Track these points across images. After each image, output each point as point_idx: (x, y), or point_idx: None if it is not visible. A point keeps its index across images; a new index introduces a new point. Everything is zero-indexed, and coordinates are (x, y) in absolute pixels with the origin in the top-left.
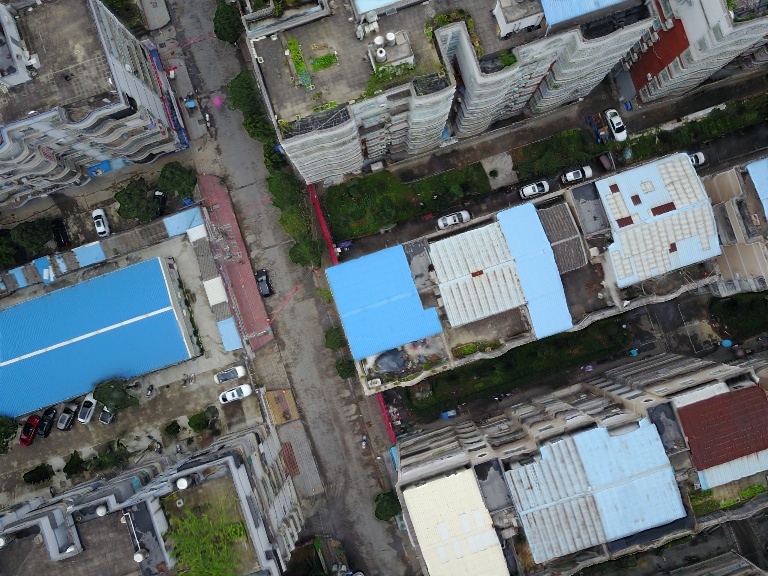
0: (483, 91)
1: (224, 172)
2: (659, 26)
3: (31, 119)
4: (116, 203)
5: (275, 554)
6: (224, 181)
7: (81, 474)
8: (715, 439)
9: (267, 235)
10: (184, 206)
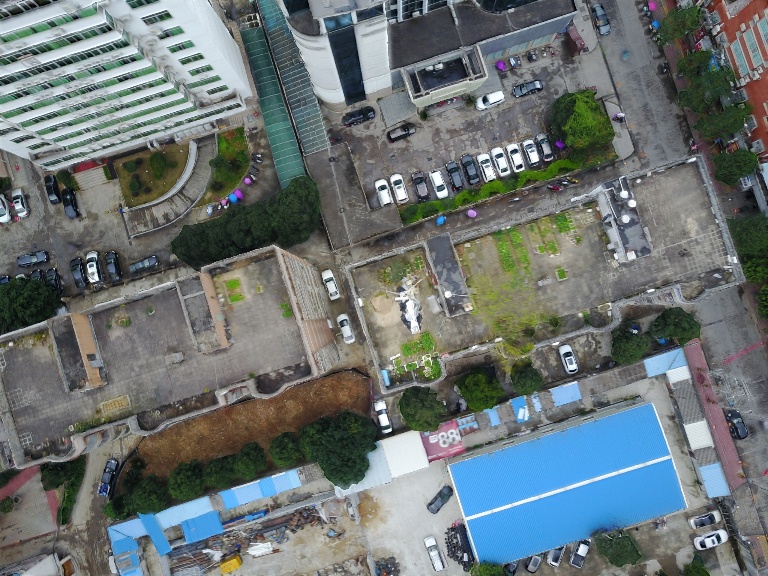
0: None
1: (691, 308)
2: None
3: None
4: (580, 338)
5: None
6: None
7: None
8: None
9: (737, 374)
10: (671, 348)
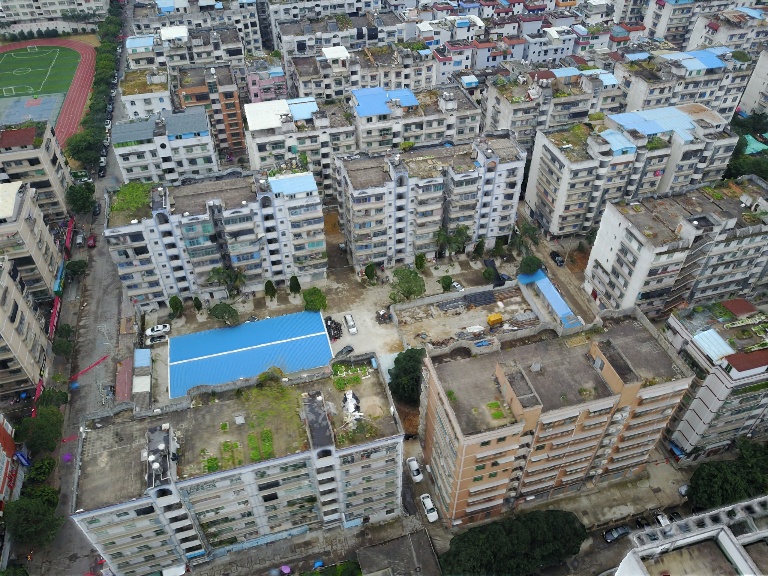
0: None
1: None
2: None
3: None
4: None
5: None
6: None
7: (279, 295)
8: None
9: None
10: None
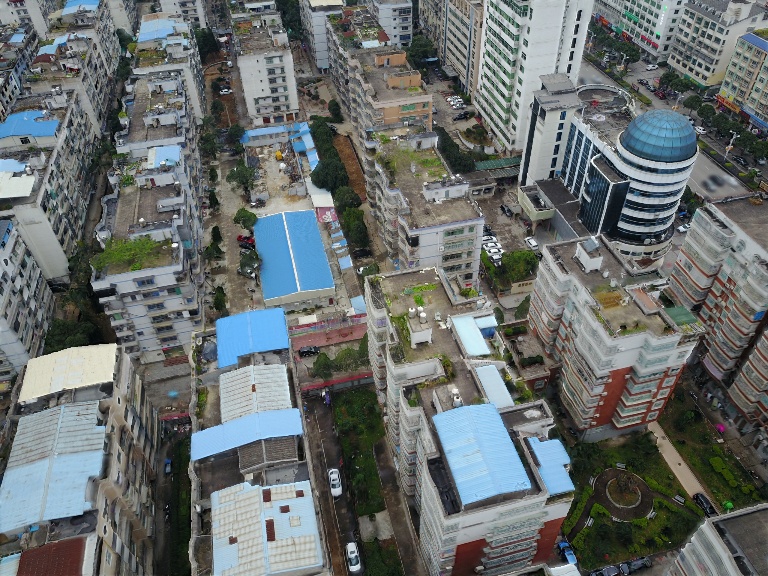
0: None
1: None
2: None
3: None
4: None
5: (112, 290)
6: None
7: None
8: (43, 569)
9: None
10: None
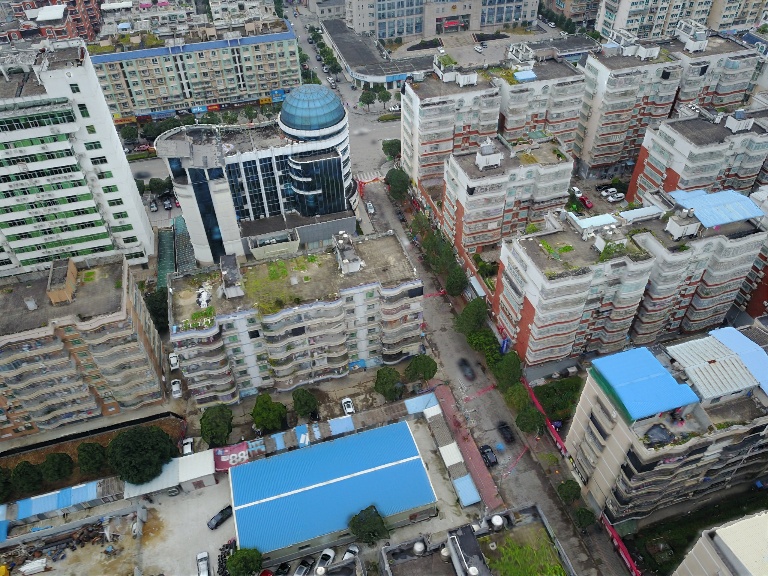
0: (668, 274)
1: (447, 378)
2: (762, 265)
3: (359, 288)
4: (360, 396)
5: None
6: (447, 383)
7: None
8: None
9: (486, 421)
10: (423, 390)
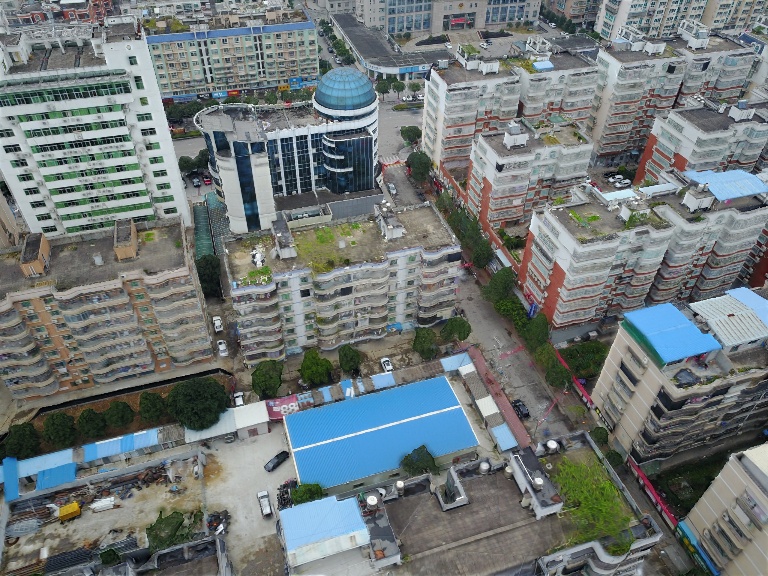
0: (685, 243)
1: (476, 341)
2: (765, 239)
3: (404, 252)
4: (397, 357)
5: None
6: None
7: None
8: None
9: (516, 379)
10: (458, 350)
